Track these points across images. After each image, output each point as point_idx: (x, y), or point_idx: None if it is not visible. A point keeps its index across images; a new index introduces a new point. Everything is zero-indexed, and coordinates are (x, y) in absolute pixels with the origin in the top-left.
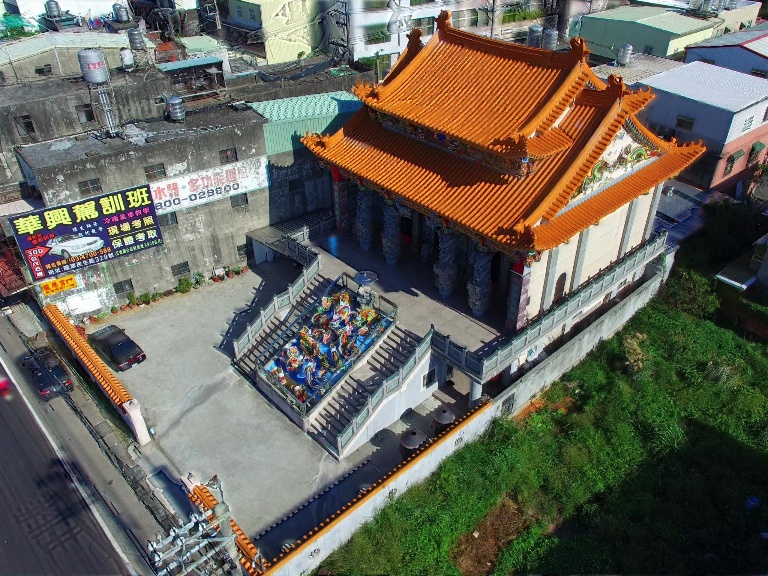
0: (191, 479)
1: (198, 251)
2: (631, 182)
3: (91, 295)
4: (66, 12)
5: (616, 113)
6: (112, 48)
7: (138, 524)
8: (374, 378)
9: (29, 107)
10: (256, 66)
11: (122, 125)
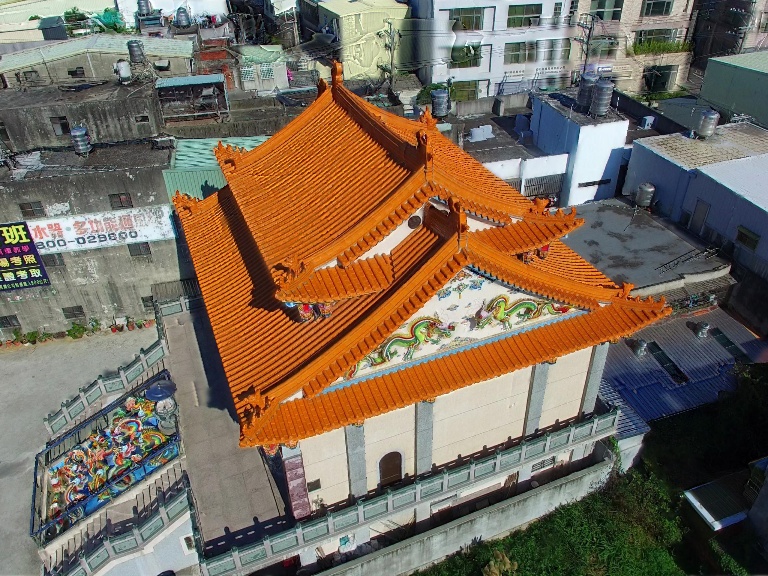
0: None
1: (93, 296)
2: (510, 347)
3: None
4: (159, 11)
5: (452, 254)
6: None
7: None
8: (126, 523)
9: (3, 115)
10: (275, 88)
11: (27, 152)
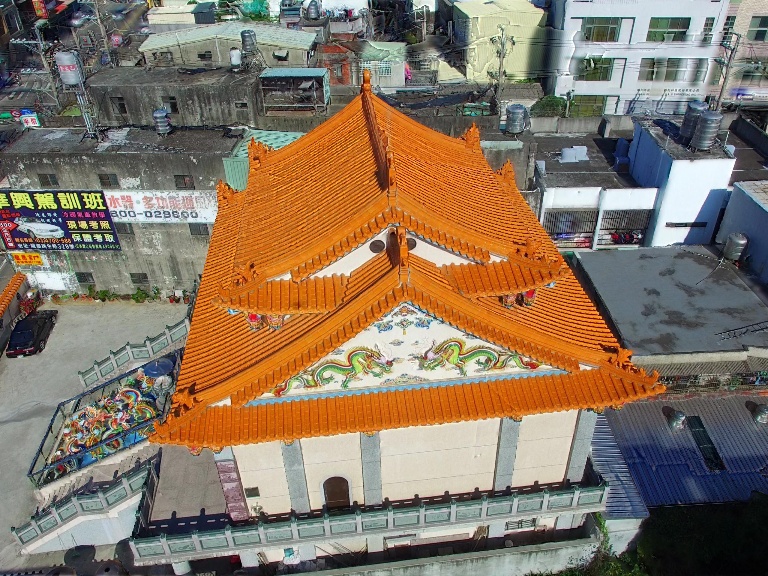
0: None
1: (157, 267)
2: (464, 394)
3: (57, 276)
4: (302, 2)
5: (391, 287)
6: (267, 44)
7: None
8: (104, 485)
9: (123, 90)
10: (377, 86)
11: (119, 127)
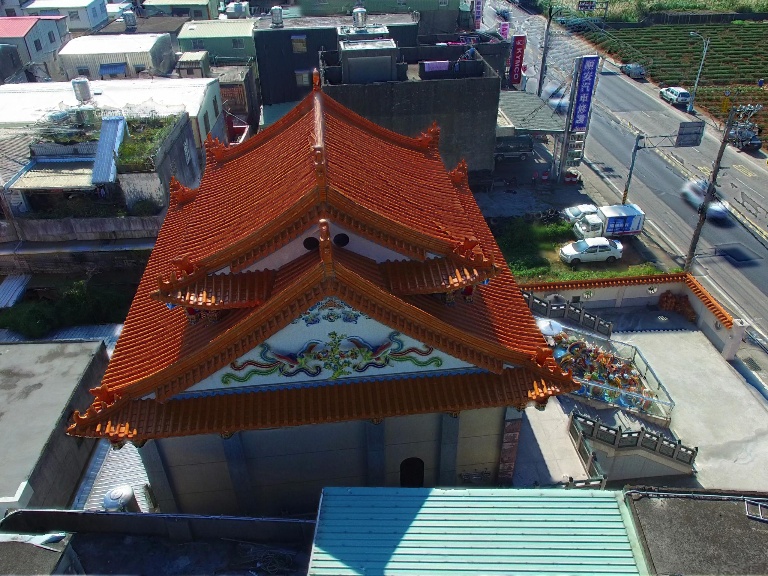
0: (741, 320)
1: None
2: None
3: None
4: None
5: None
6: None
7: None
8: None
9: None
10: None
11: None
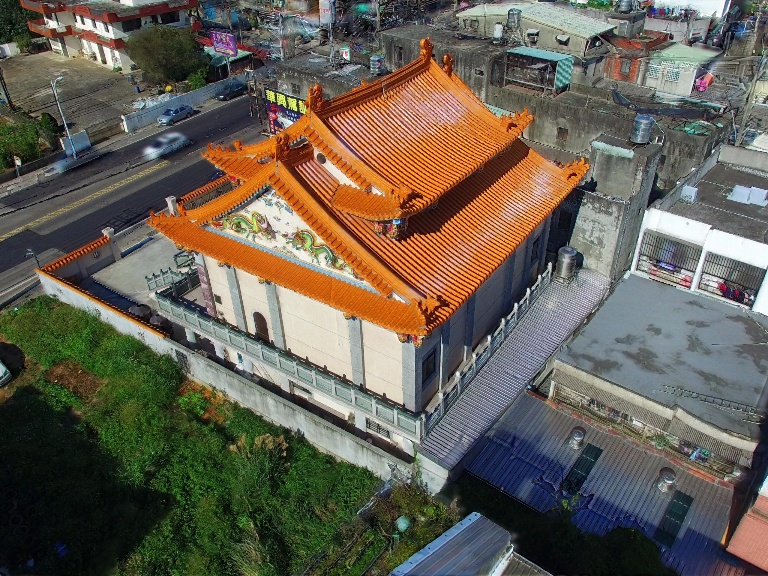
0: None
1: None
2: (313, 278)
3: None
4: None
5: None
6: (554, 27)
7: (117, 243)
8: None
9: (403, 42)
10: None
11: (356, 63)
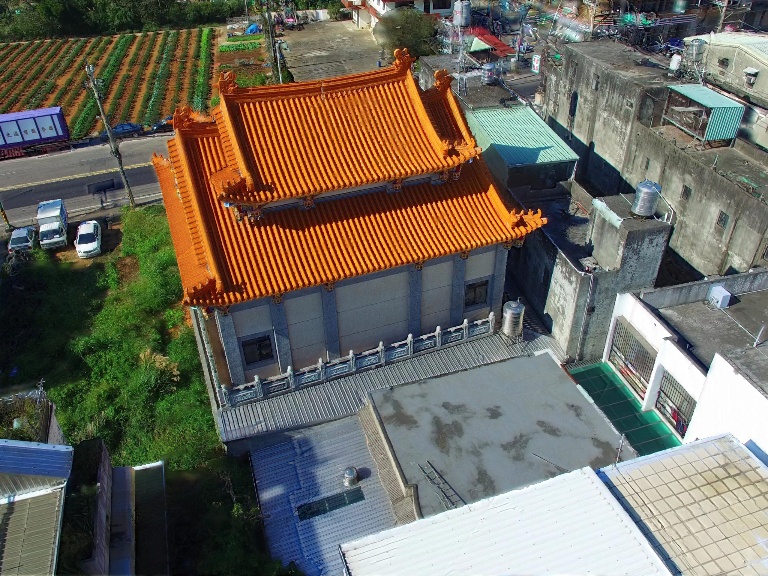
0: None
1: None
2: None
3: None
4: None
5: None
6: None
7: None
8: None
9: None
10: None
11: None
